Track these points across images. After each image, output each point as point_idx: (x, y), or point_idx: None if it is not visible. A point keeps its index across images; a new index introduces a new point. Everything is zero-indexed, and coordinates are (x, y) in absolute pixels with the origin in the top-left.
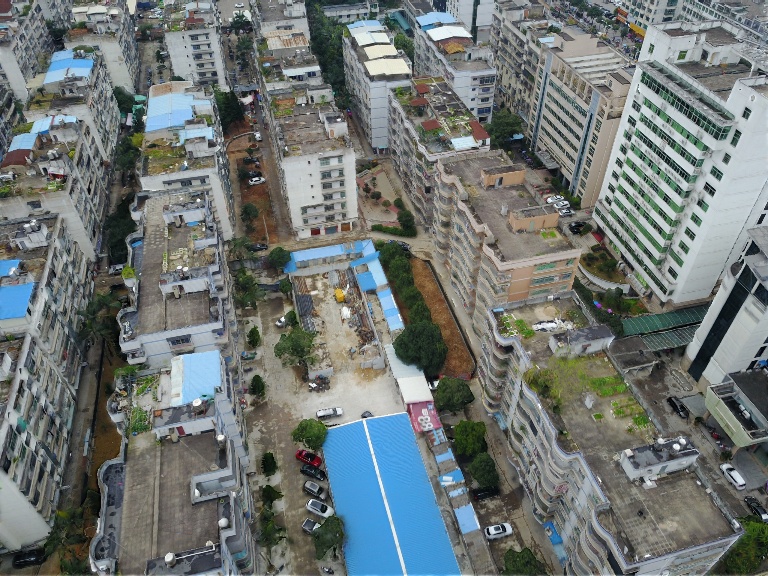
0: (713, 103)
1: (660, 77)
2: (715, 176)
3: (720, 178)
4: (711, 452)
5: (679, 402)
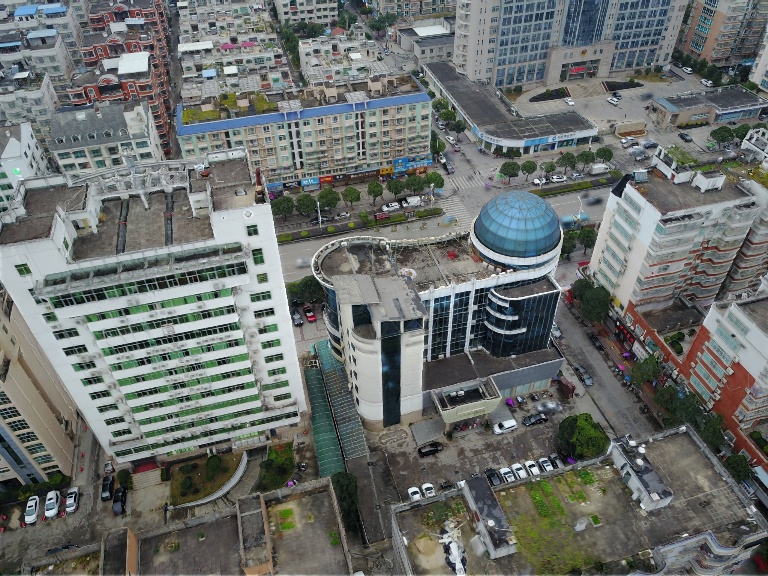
0: (197, 251)
1: (96, 282)
2: (261, 300)
3: (269, 296)
4: (479, 437)
5: (427, 447)
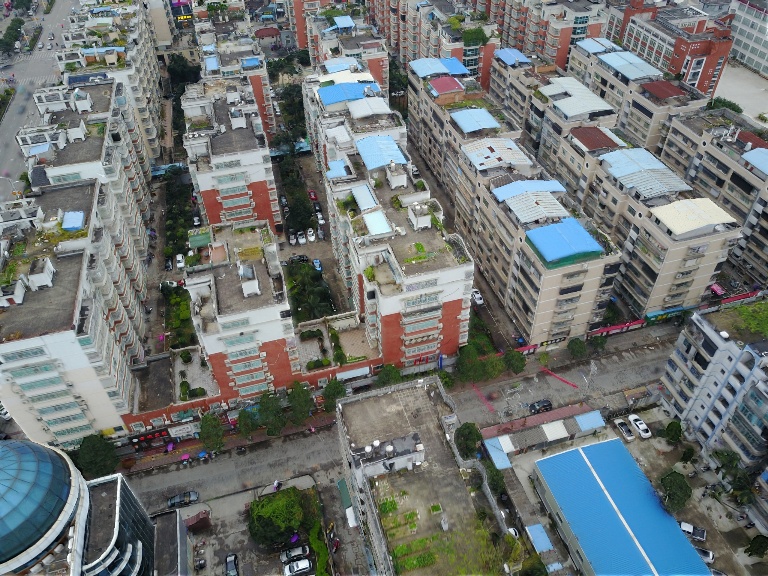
0: None
1: None
2: None
3: None
4: None
5: None
